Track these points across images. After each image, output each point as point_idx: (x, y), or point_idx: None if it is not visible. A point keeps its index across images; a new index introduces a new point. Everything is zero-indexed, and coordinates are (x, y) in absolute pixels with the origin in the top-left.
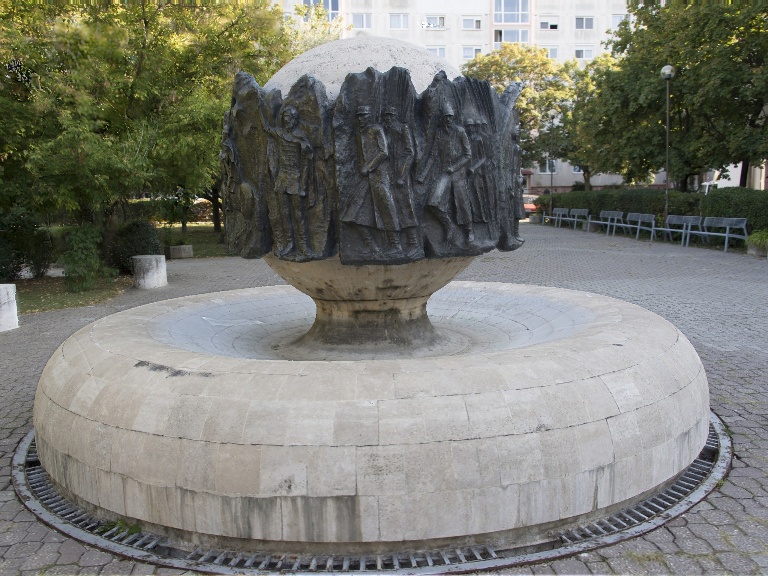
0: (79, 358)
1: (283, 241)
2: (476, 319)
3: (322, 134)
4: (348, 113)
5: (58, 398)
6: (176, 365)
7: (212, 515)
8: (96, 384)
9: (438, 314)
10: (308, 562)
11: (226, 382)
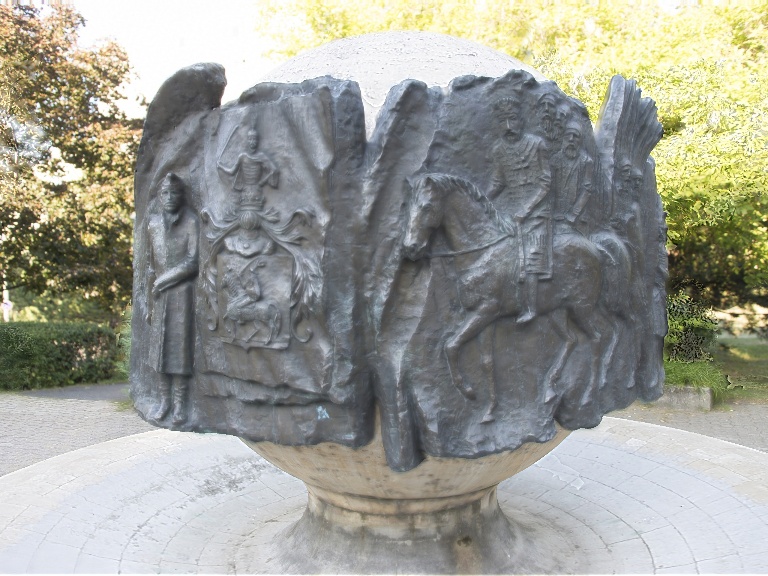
0: None
1: None
2: None
3: None
4: None
5: None
6: None
7: None
8: None
9: None
10: None
11: None
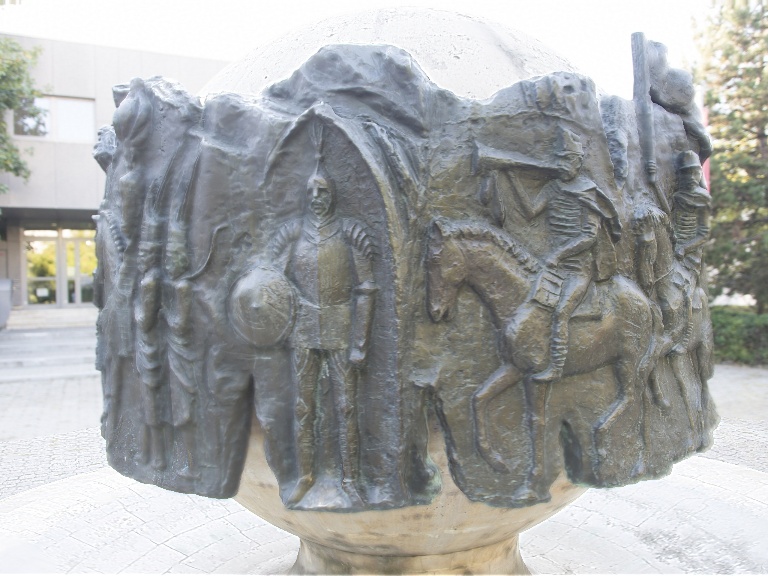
0: None
1: None
2: (228, 533)
3: None
4: None
5: None
6: None
7: None
8: None
9: (161, 568)
10: None
11: None
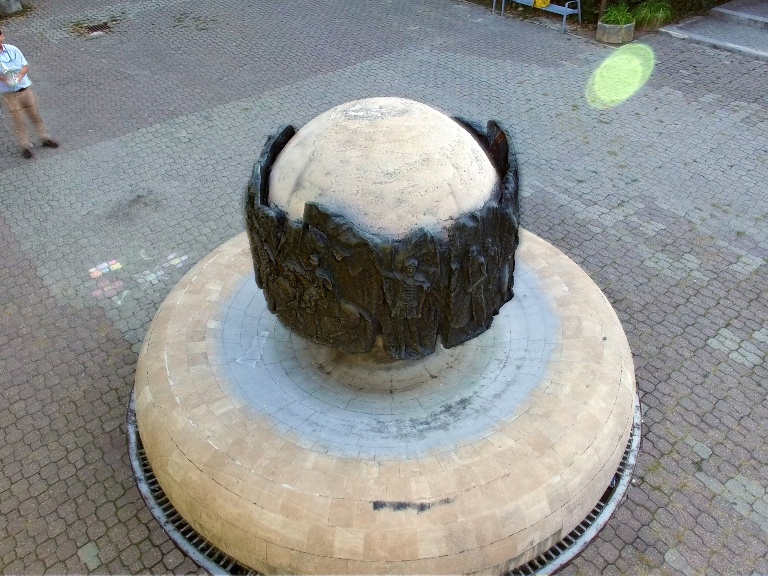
0: (293, 509)
1: (396, 345)
2: None
3: (440, 275)
4: (460, 254)
5: (308, 550)
6: (411, 499)
7: (486, 575)
8: (352, 535)
9: None
10: (529, 561)
11: (467, 503)
